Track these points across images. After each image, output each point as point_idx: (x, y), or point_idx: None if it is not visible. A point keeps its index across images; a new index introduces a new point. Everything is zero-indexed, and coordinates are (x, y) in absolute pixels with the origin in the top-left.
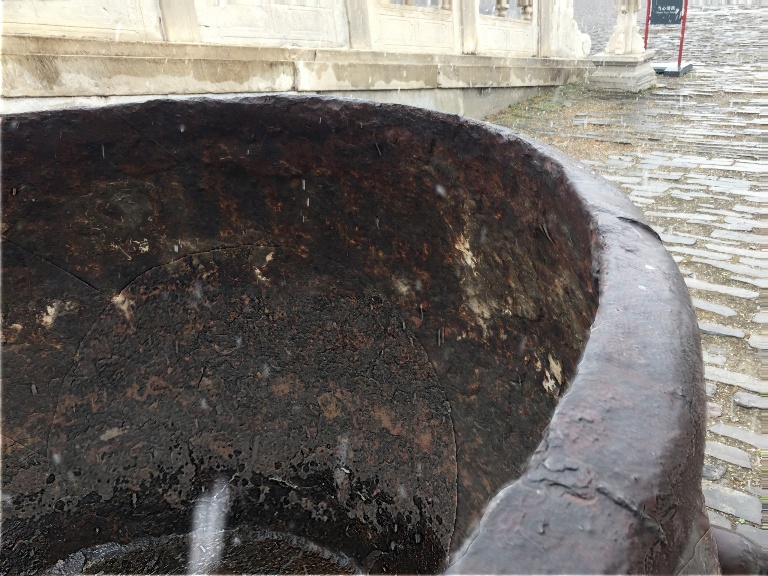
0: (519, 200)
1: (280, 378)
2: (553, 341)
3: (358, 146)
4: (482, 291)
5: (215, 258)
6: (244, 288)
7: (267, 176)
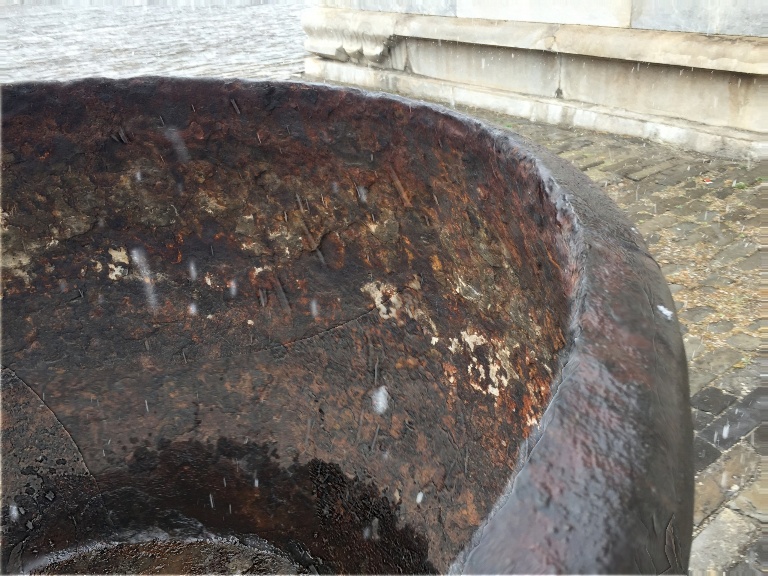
0: (81, 127)
1: None
2: (111, 236)
3: None
4: (17, 241)
5: None
6: None
7: None
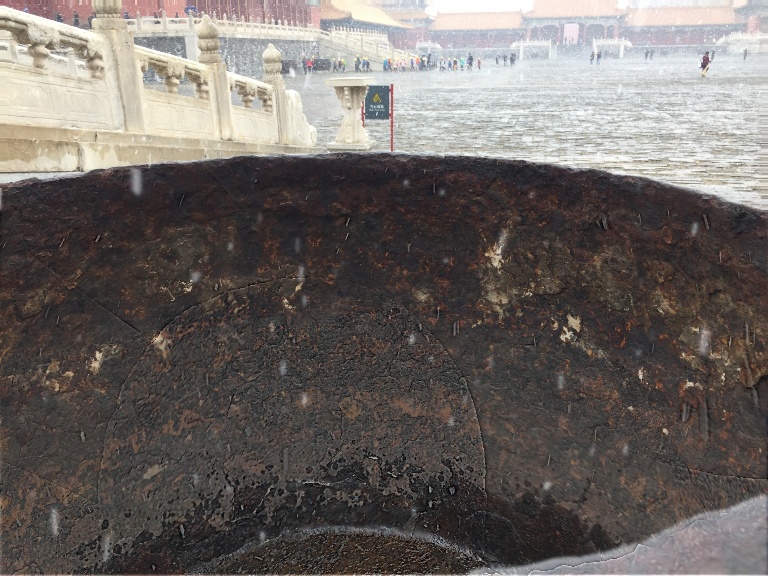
0: (575, 208)
1: (303, 393)
2: (573, 304)
3: (415, 187)
4: (504, 284)
5: (249, 293)
6: (270, 318)
7: (317, 217)
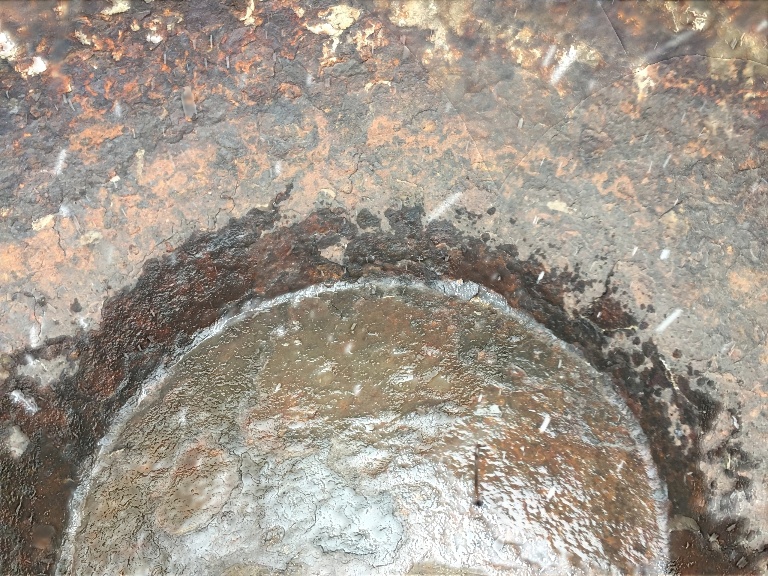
0: None
1: (749, 270)
2: None
3: None
4: None
5: None
6: None
7: None
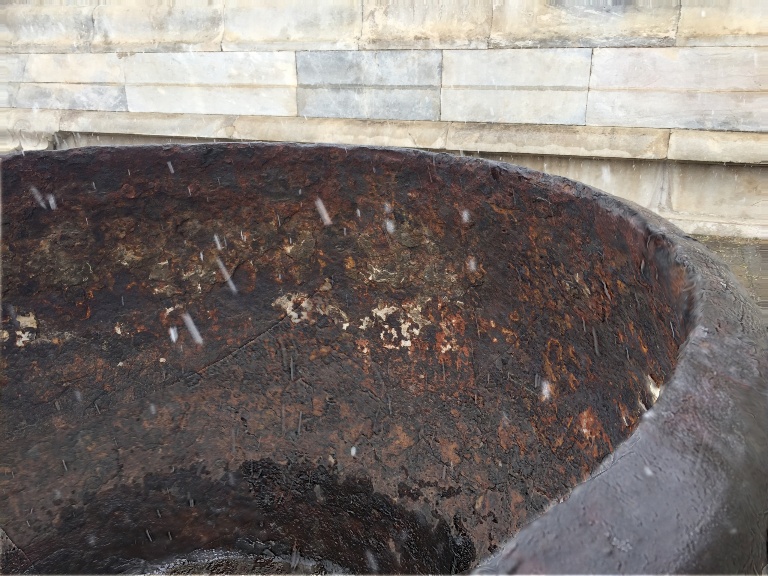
0: (12, 198)
1: None
2: (20, 303)
3: None
4: None
5: None
6: None
7: None
